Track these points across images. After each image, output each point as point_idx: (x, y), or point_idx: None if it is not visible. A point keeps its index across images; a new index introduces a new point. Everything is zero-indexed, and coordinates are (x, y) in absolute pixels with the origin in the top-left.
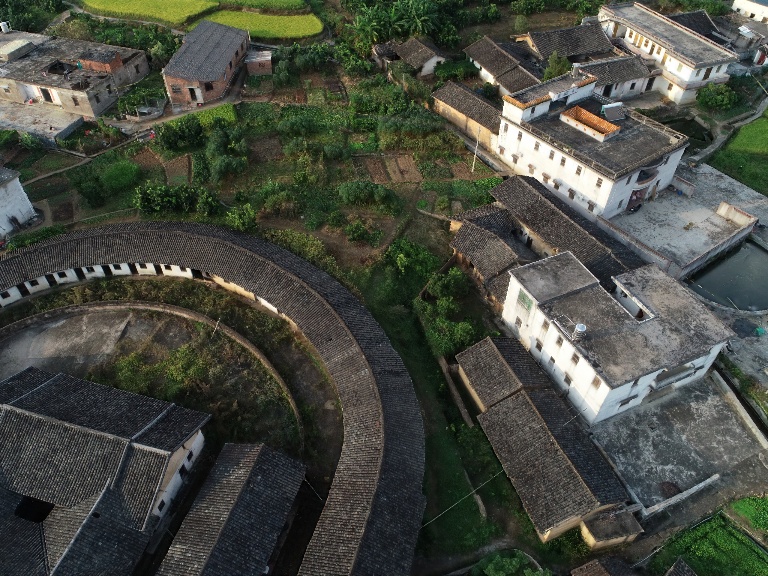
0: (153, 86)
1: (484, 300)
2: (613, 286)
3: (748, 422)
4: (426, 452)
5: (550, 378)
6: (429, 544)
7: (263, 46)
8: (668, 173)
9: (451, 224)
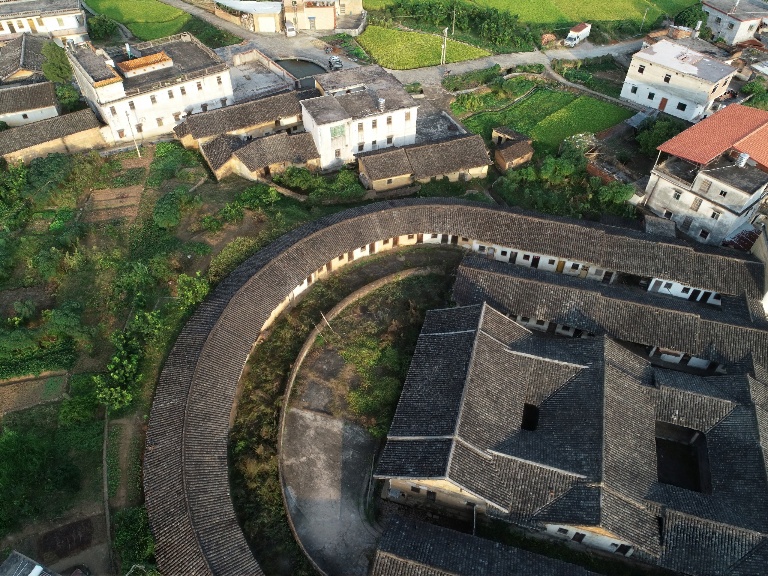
0: None
1: None
2: None
3: None
4: None
5: None
6: None
7: None
8: None
9: (217, 174)
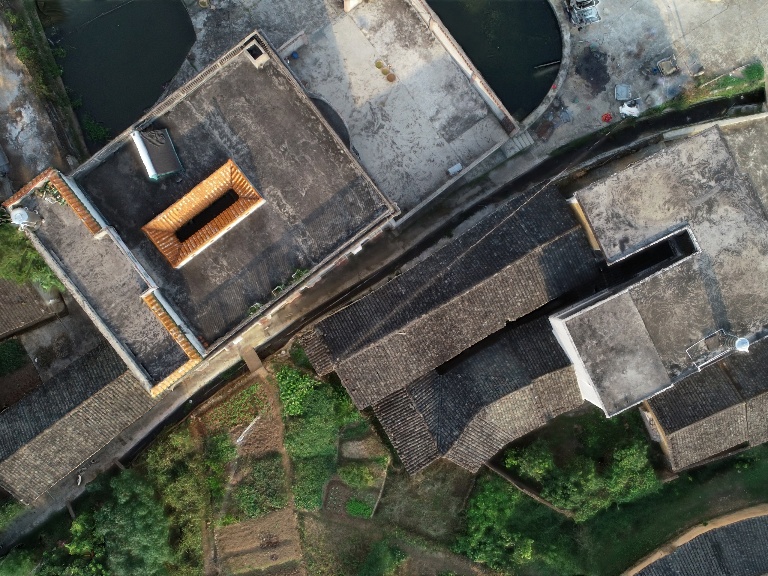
0: None
1: None
2: (592, 255)
3: None
4: (767, 495)
5: None
6: None
7: None
8: None
9: None
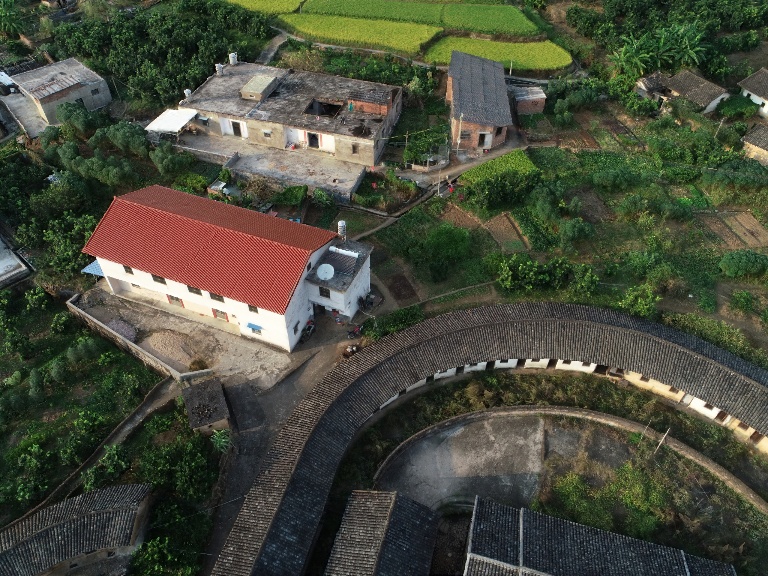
0: (419, 128)
1: None
2: None
3: None
4: None
5: None
6: None
7: (515, 79)
8: None
9: None
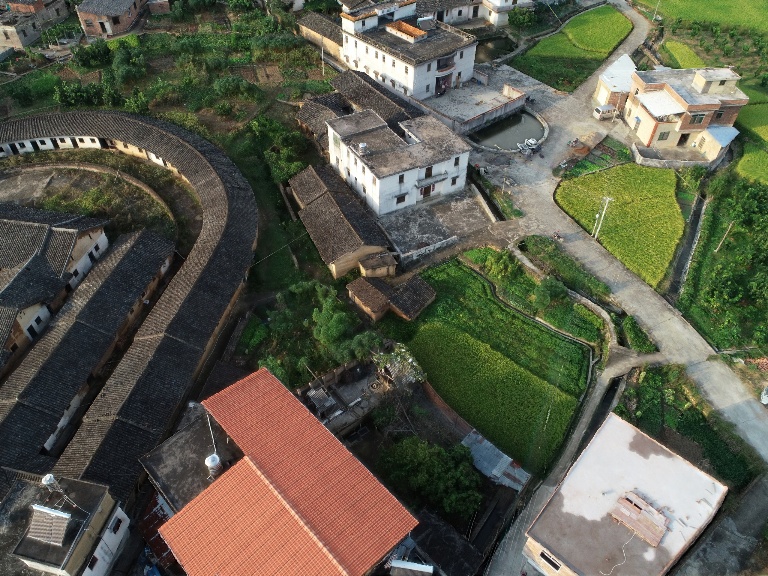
0: None
1: (320, 155)
2: (403, 132)
3: (486, 210)
4: (263, 238)
5: (357, 194)
6: (260, 285)
7: None
8: (467, 67)
9: (300, 107)
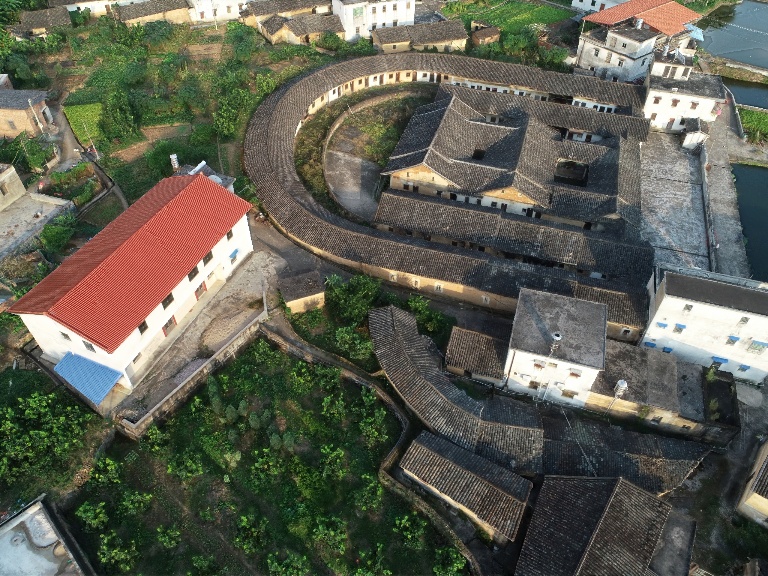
0: None
1: None
2: None
3: None
4: None
5: None
6: None
7: None
8: None
9: (273, 39)
